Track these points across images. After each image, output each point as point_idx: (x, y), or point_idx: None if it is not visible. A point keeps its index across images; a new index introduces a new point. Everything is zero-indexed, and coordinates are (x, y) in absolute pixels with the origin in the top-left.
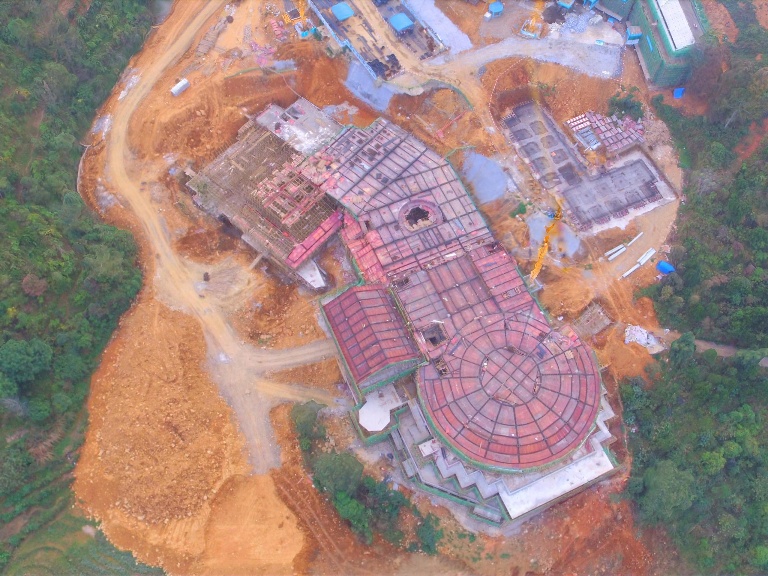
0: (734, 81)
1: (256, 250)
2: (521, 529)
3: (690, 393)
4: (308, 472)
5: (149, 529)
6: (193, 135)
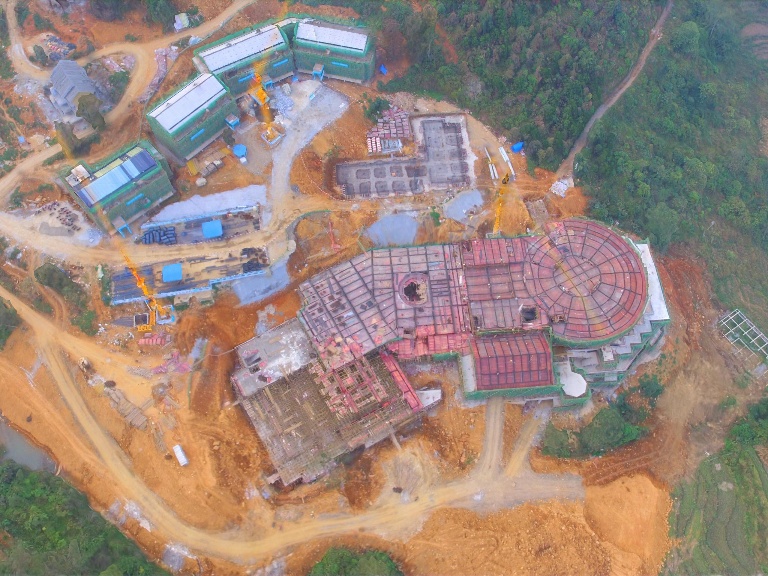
0: (418, 30)
1: (384, 439)
2: None
3: (602, 179)
4: (588, 458)
5: None
6: (237, 462)
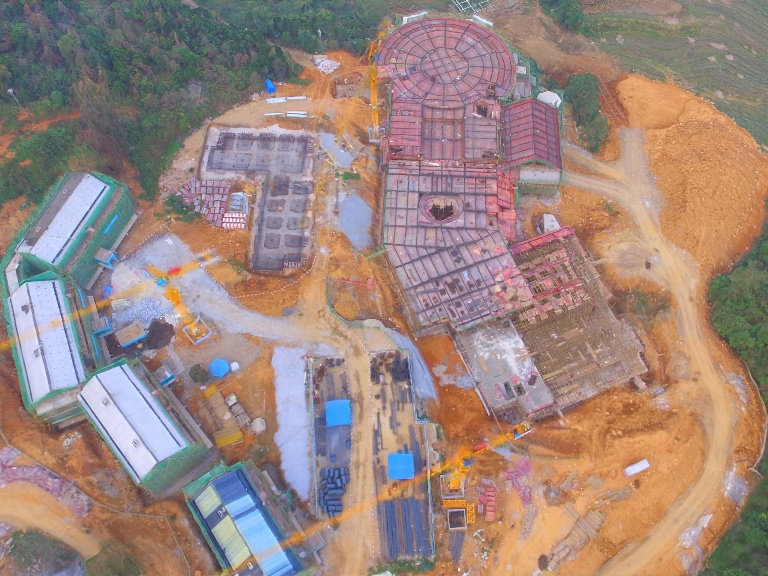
0: None
1: None
2: None
3: None
4: None
5: (725, 124)
6: None
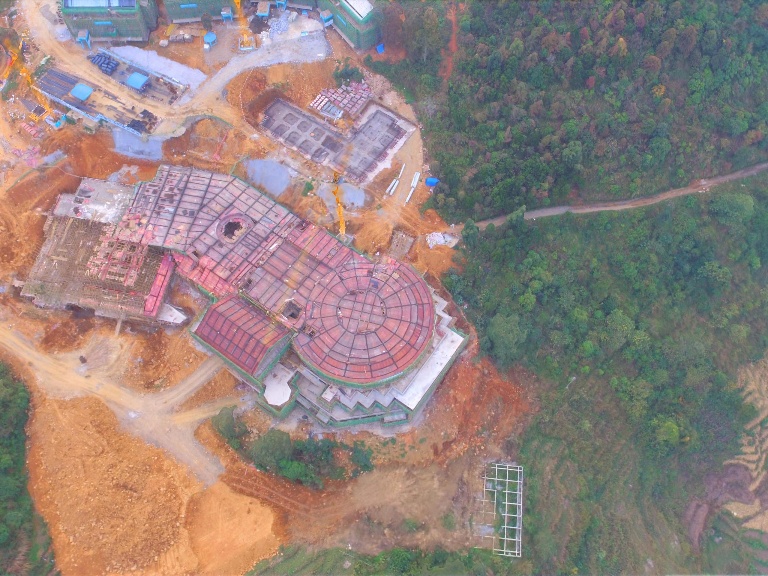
0: (413, 26)
1: (113, 318)
2: (424, 416)
3: (491, 262)
4: (249, 463)
5: (145, 573)
6: (4, 251)
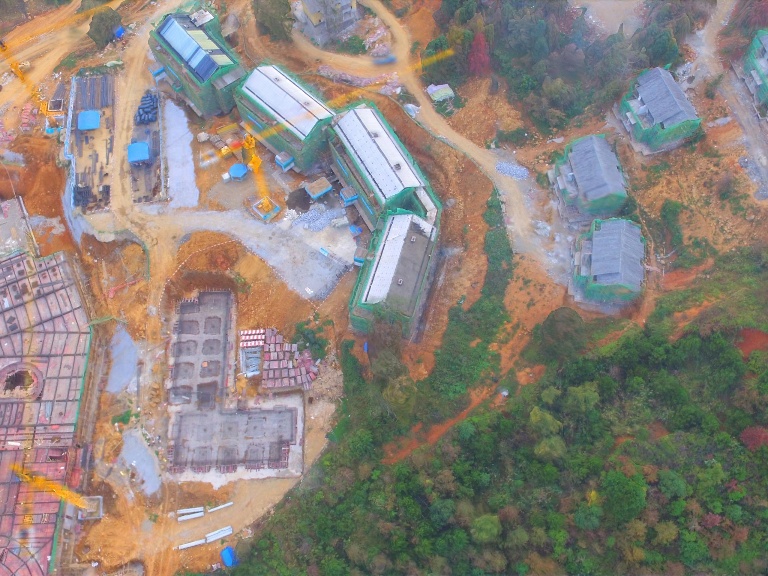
0: None
1: None
2: None
3: None
4: None
5: None
6: None
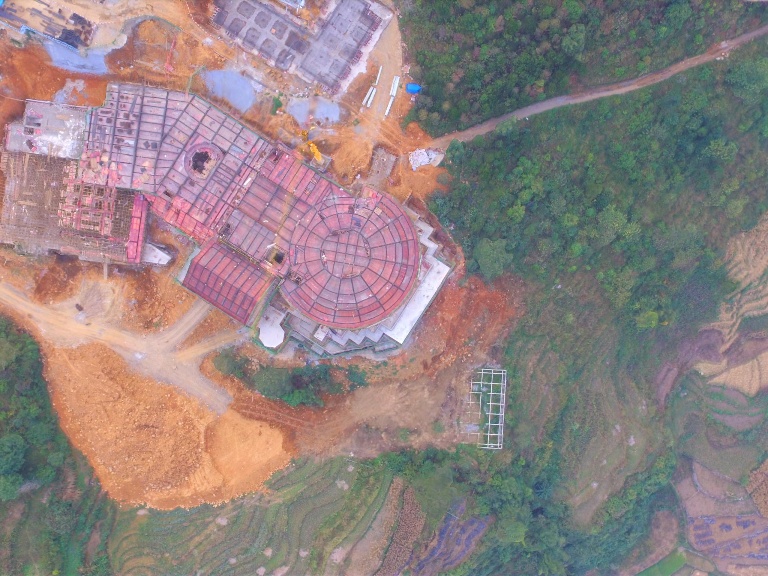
0: None
1: (98, 262)
2: (413, 339)
3: (478, 175)
4: (254, 390)
5: (180, 490)
6: None
